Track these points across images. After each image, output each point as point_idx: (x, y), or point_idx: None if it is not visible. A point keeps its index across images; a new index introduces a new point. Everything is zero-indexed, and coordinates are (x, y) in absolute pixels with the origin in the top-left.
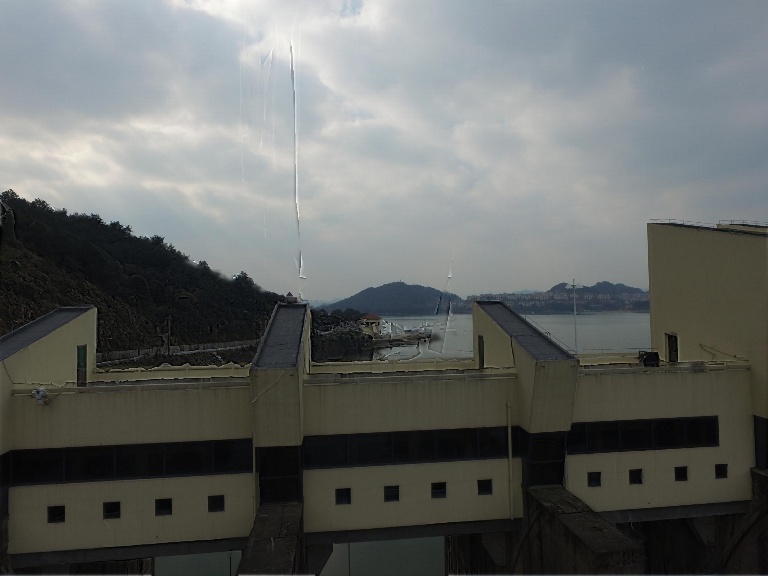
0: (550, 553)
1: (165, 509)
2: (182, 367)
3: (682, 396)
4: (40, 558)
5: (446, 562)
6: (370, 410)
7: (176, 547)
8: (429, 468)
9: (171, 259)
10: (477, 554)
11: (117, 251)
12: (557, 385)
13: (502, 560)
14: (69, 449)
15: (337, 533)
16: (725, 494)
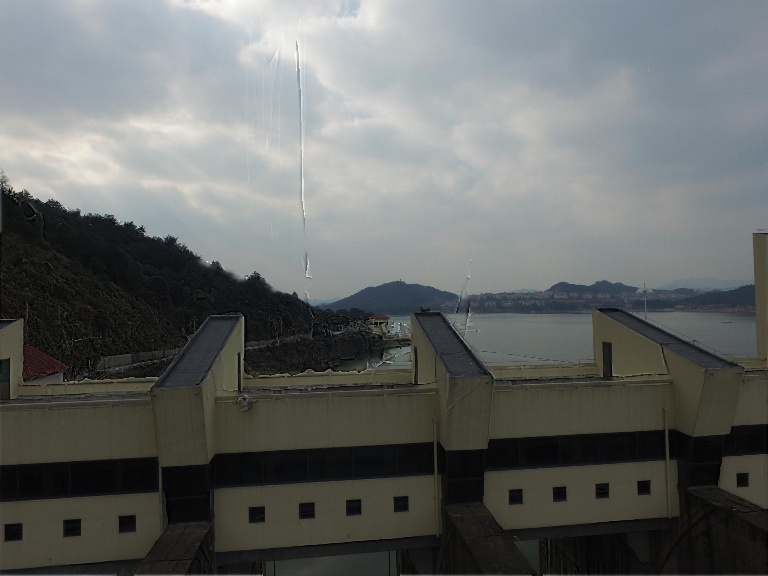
0: (726, 550)
1: (355, 509)
2: (325, 373)
3: None
4: (241, 556)
5: (542, 559)
6: (539, 415)
7: (364, 545)
8: (593, 470)
9: (186, 259)
10: (599, 551)
11: (133, 252)
12: (722, 391)
13: (646, 557)
14: (267, 453)
15: (510, 532)
16: None
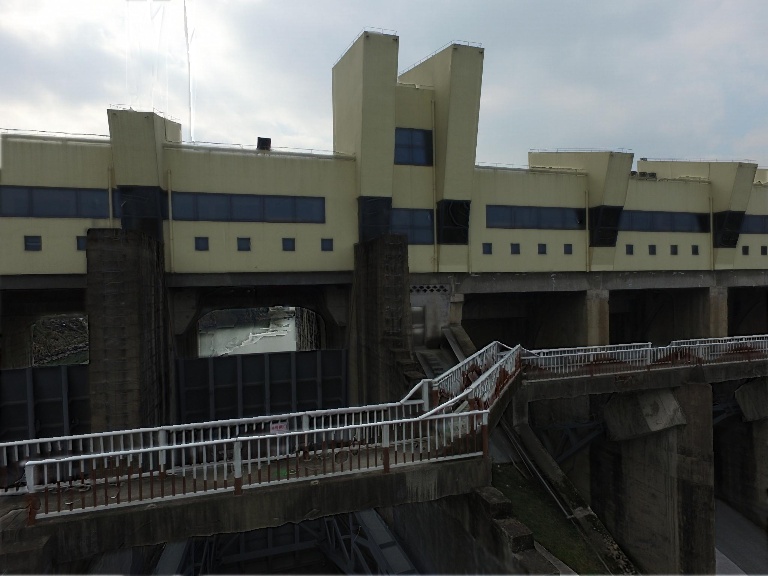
0: None
1: None
2: None
3: (291, 178)
4: None
5: None
6: None
7: None
8: (22, 222)
9: None
10: None
11: None
12: (135, 136)
13: None
14: None
15: None
16: (330, 264)
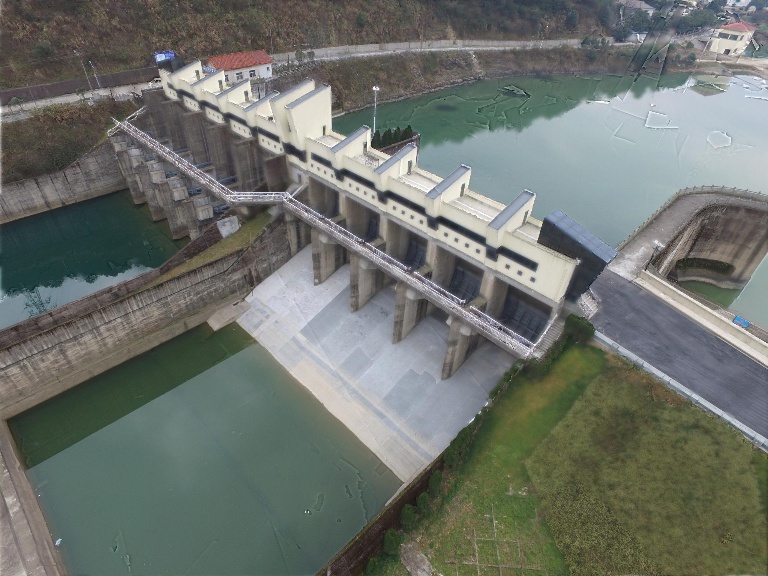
0: None
1: None
2: None
3: None
4: (210, 119)
5: None
6: None
7: None
8: None
9: None
10: None
11: None
12: None
13: None
14: (208, 102)
15: (235, 132)
16: None
